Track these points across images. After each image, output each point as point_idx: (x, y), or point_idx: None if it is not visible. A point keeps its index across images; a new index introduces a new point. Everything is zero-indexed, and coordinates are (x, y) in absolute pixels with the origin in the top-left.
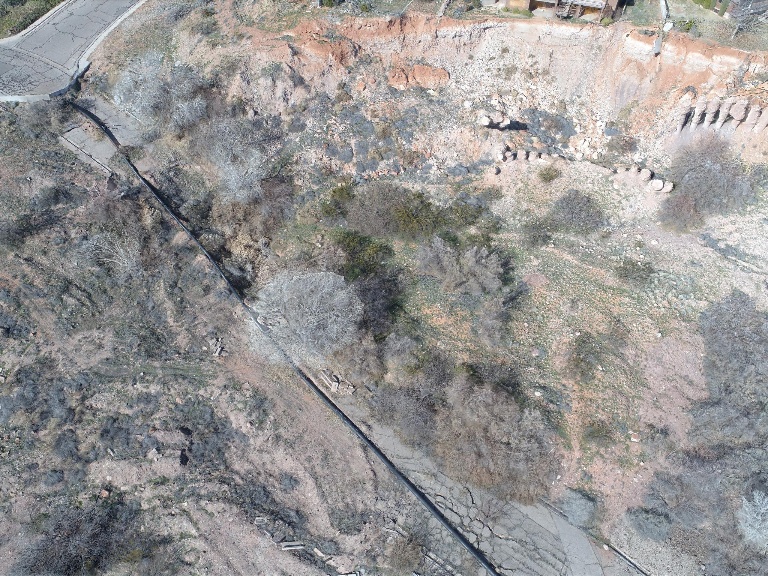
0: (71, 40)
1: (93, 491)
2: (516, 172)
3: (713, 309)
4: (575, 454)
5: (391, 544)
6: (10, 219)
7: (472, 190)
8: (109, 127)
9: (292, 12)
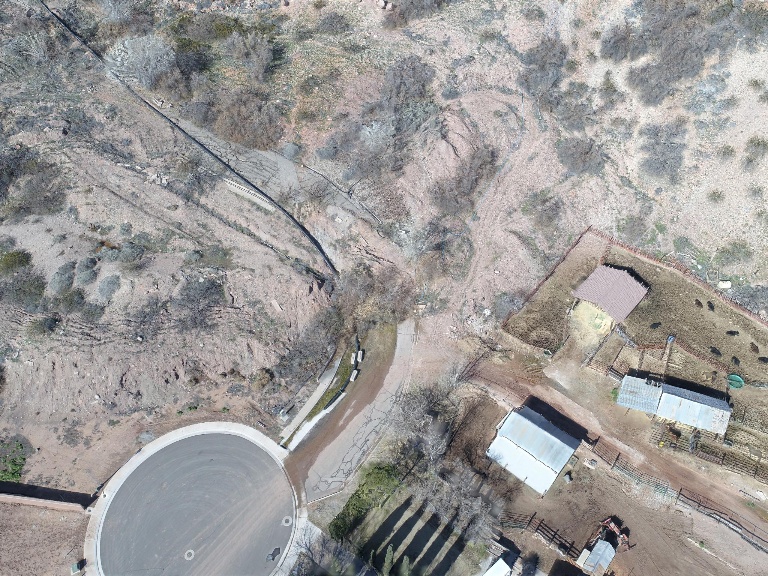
0: None
1: (11, 146)
2: (299, 4)
3: (396, 64)
4: (292, 125)
5: (179, 163)
6: None
7: (271, 17)
8: None
9: None
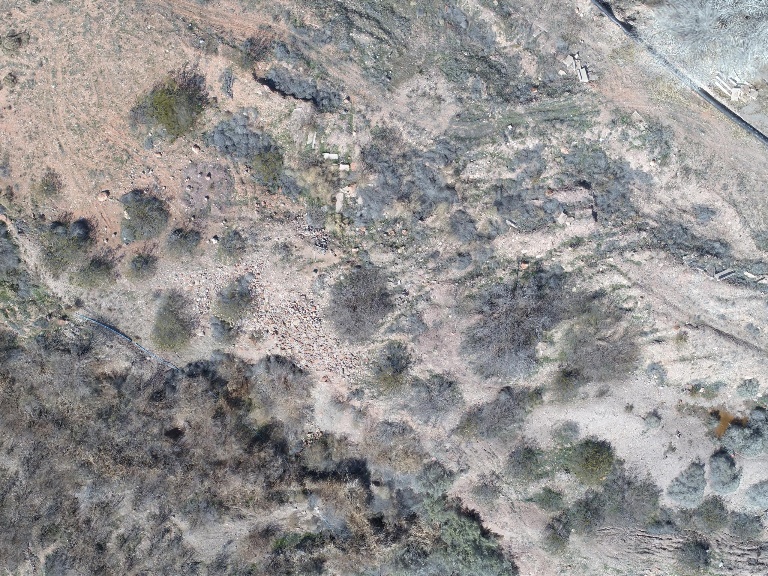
0: None
1: (511, 266)
2: None
3: None
4: None
5: None
6: None
7: None
8: None
9: None
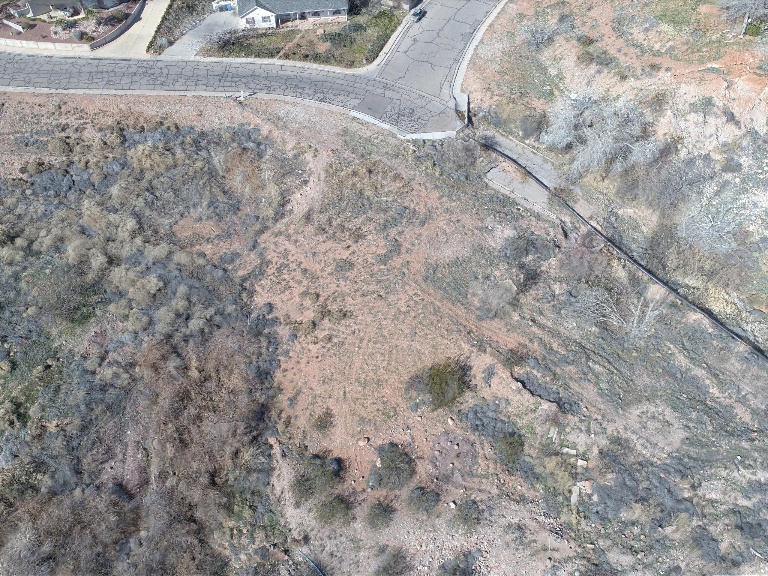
0: (432, 69)
1: None
2: None
3: None
4: None
5: None
6: (522, 277)
7: None
8: (526, 167)
9: (709, 41)
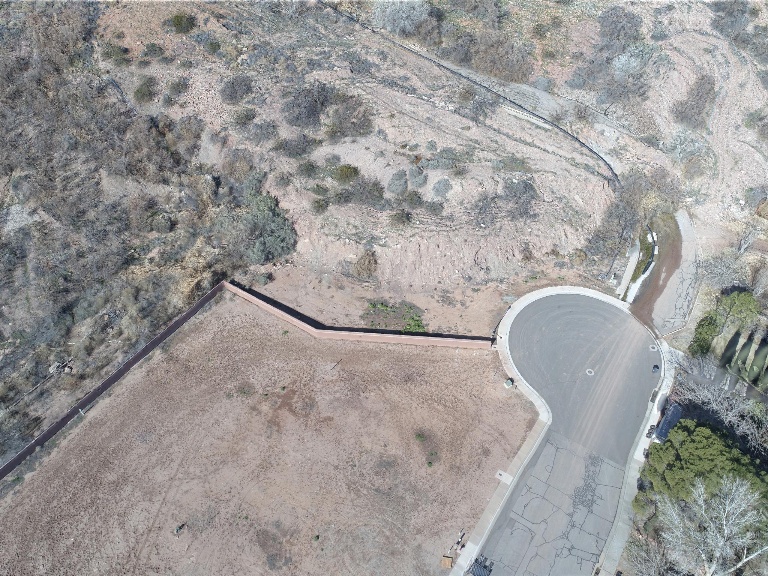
0: None
1: (311, 83)
2: None
3: (604, 14)
4: (539, 63)
5: (458, 93)
6: None
7: None
8: None
9: None
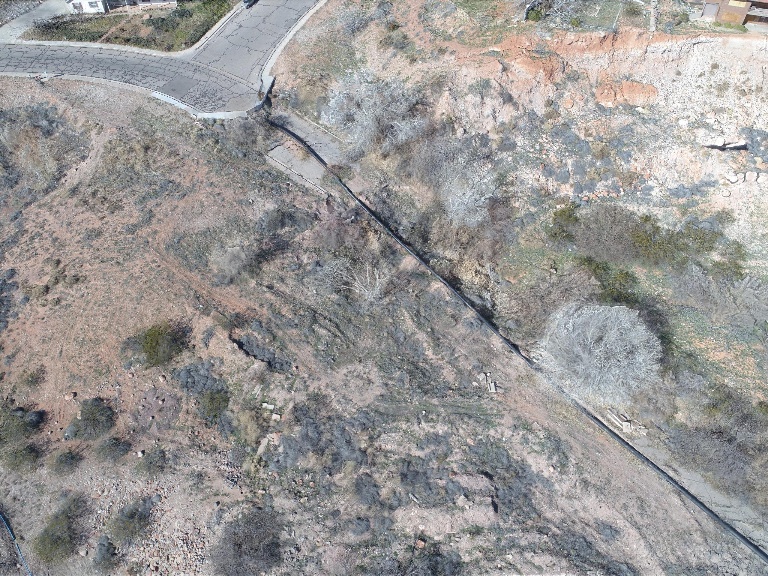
0: (247, 53)
1: (407, 541)
2: (747, 195)
3: None
4: None
5: None
6: (255, 245)
7: (701, 213)
8: (311, 145)
9: (495, 26)
